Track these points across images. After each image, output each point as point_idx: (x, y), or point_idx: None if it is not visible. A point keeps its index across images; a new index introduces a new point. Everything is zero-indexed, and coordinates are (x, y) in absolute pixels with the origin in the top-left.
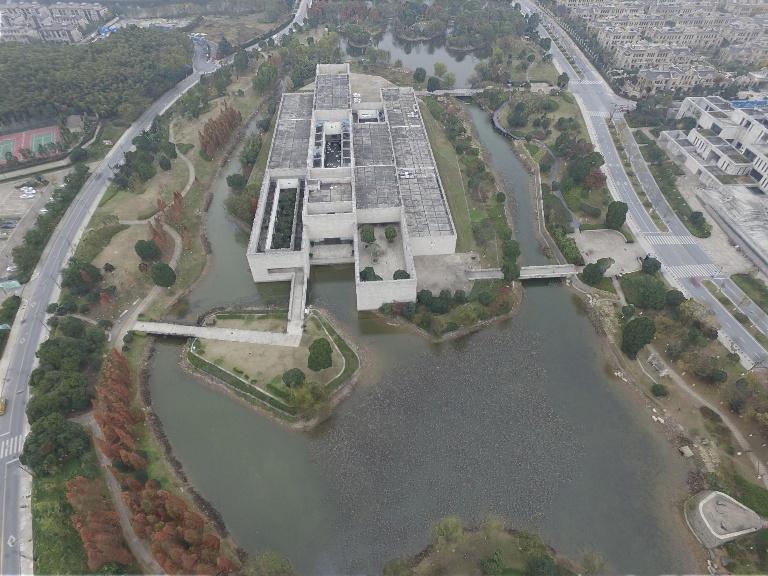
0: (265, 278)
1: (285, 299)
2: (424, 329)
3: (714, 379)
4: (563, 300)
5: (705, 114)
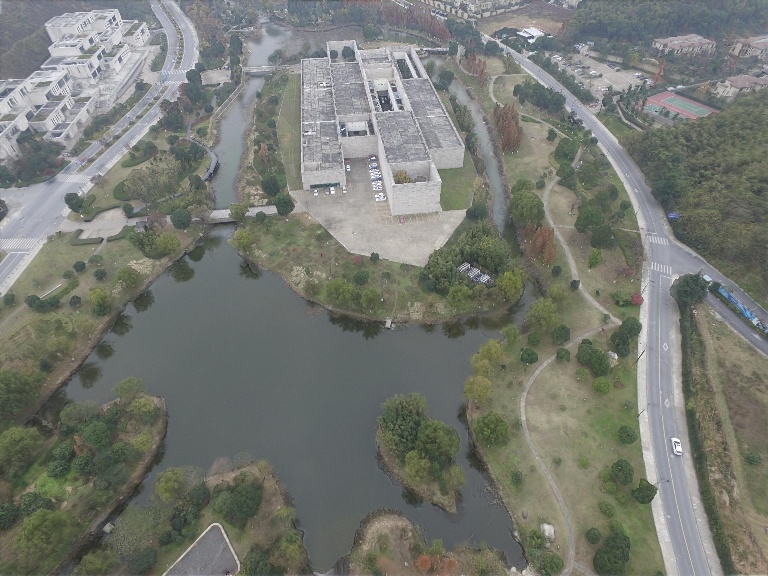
0: None
1: None
2: None
3: None
4: None
5: (18, 120)
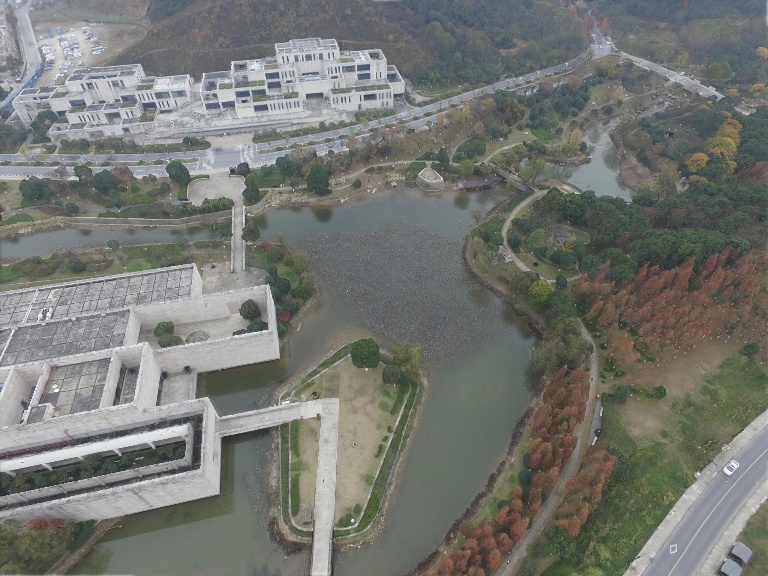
0: (218, 475)
1: (257, 442)
2: (307, 300)
3: (350, 160)
4: (269, 220)
5: (52, 101)
